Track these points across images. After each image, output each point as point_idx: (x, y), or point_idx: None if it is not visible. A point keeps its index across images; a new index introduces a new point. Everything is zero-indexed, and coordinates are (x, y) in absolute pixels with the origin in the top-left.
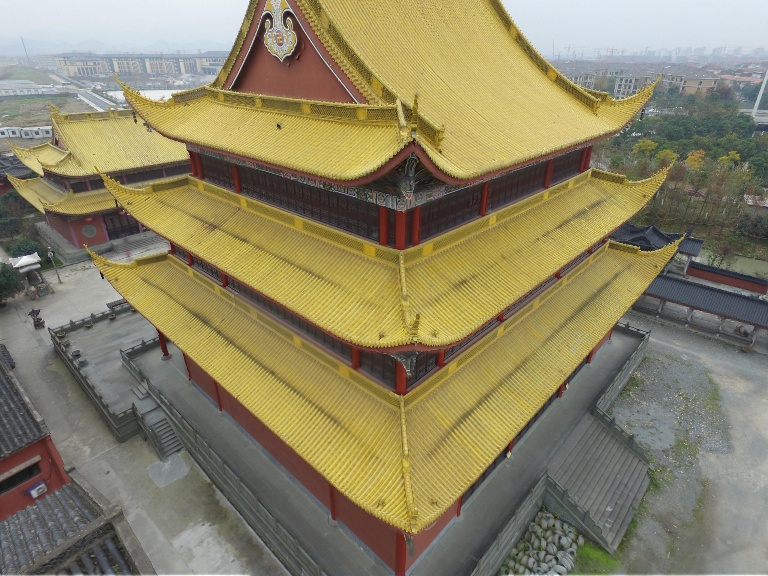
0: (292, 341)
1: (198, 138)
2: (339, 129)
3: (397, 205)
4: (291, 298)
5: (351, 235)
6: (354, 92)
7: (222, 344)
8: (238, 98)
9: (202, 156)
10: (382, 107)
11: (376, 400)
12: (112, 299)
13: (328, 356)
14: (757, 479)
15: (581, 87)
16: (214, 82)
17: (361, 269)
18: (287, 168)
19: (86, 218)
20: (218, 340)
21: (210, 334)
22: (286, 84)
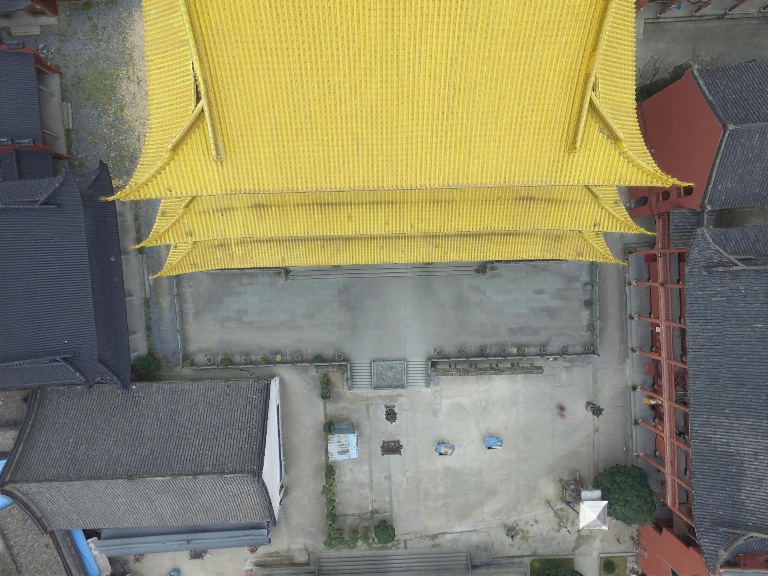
0: None
1: None
2: None
3: None
4: None
5: None
6: None
7: None
8: None
9: None
10: None
11: None
12: (519, 418)
13: None
14: None
15: None
16: None
17: None
18: None
19: None
20: None
21: None
22: None
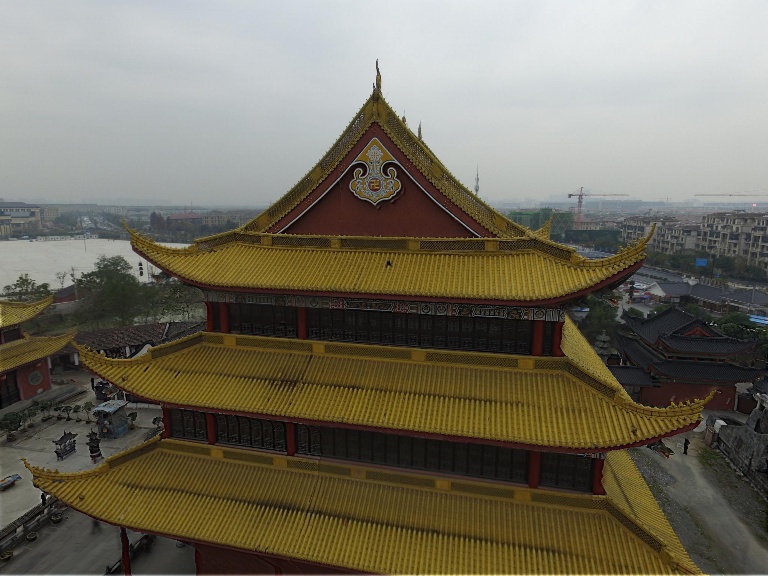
0: (433, 488)
1: (280, 283)
2: (466, 260)
3: (560, 317)
4: (483, 428)
5: (500, 354)
6: (476, 228)
7: (337, 525)
8: (299, 240)
9: (233, 306)
10: (518, 239)
11: (574, 512)
12: None
13: (498, 486)
14: (705, 493)
15: None
16: (246, 226)
17: (527, 383)
18: (455, 298)
19: None
20: (326, 522)
21: (308, 519)
22: (371, 225)
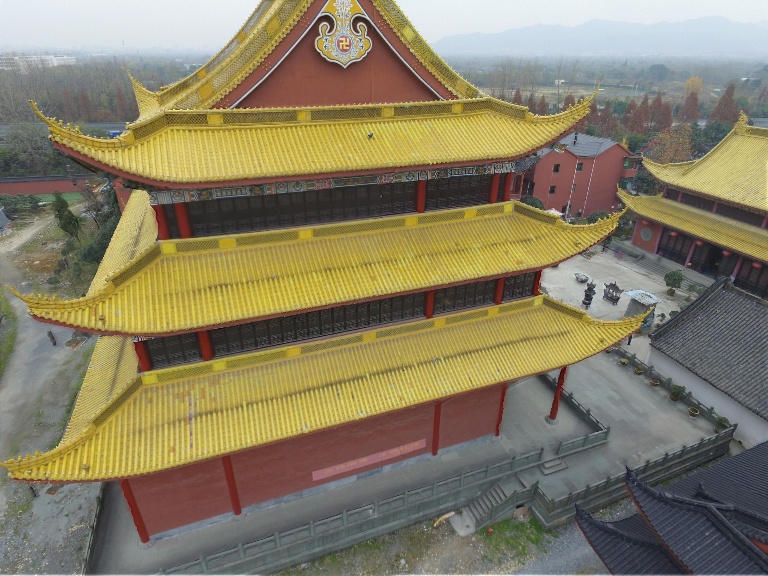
0: None
1: None
2: None
3: None
4: None
5: None
6: None
7: None
8: None
9: None
10: None
11: None
12: None
13: None
14: None
15: (163, 111)
16: None
17: None
18: None
19: (643, 220)
20: None
21: None
22: None
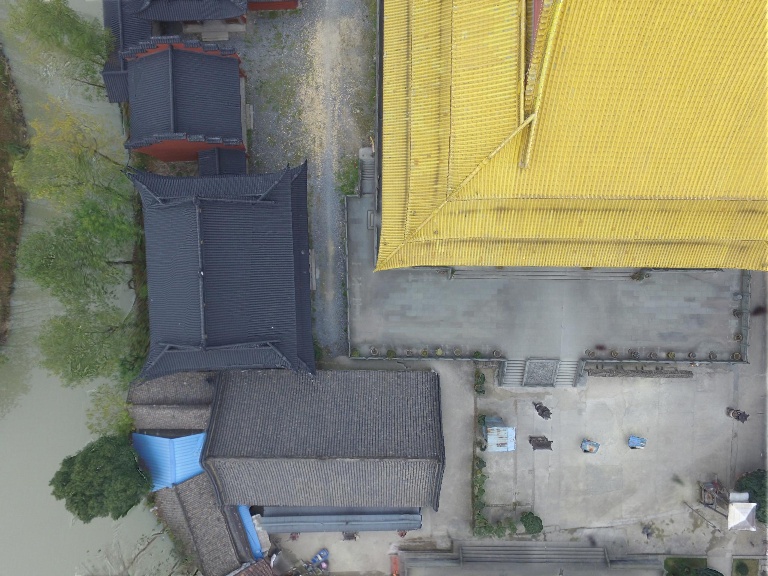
0: None
1: None
2: None
3: None
4: None
5: None
6: None
7: None
8: None
9: None
10: None
11: None
12: (661, 420)
13: None
14: None
15: None
16: None
17: None
18: None
19: None
20: None
21: None
22: None
